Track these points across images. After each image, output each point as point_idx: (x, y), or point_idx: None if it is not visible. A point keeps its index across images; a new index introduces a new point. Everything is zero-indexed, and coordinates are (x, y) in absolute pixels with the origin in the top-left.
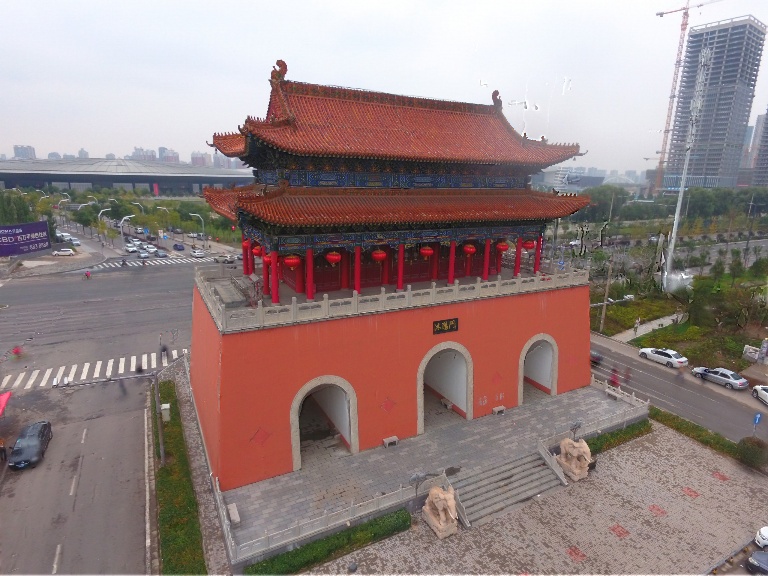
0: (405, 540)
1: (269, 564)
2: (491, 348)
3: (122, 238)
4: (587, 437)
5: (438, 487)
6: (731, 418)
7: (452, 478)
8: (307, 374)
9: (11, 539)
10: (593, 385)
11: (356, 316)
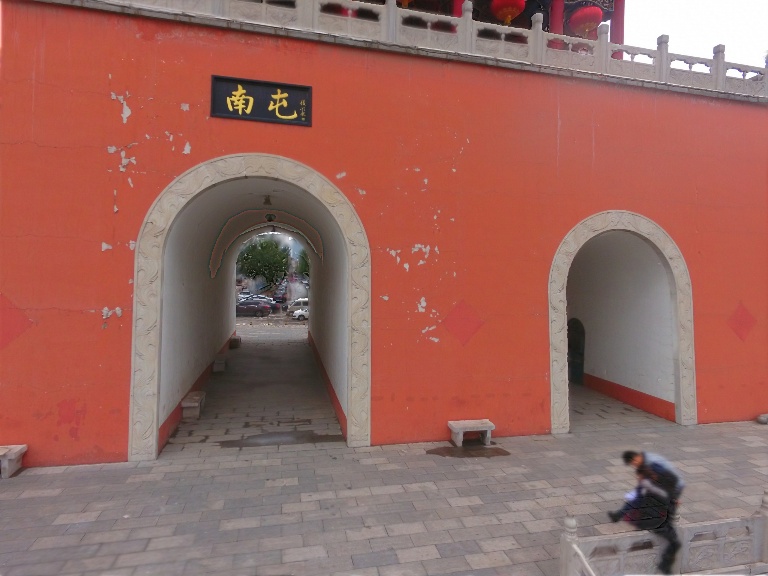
0: None
1: None
2: None
3: (767, 49)
4: None
5: None
6: None
7: None
8: None
9: None
10: None
11: None
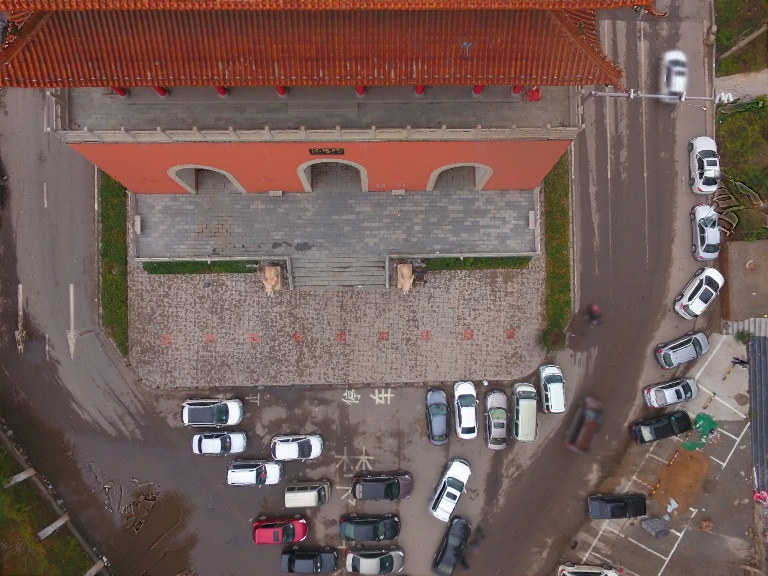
0: (247, 280)
1: (157, 266)
2: (393, 164)
3: None
4: (447, 257)
5: (270, 271)
6: (623, 286)
7: (299, 254)
8: (173, 161)
9: (16, 164)
10: (534, 193)
11: (205, 142)
